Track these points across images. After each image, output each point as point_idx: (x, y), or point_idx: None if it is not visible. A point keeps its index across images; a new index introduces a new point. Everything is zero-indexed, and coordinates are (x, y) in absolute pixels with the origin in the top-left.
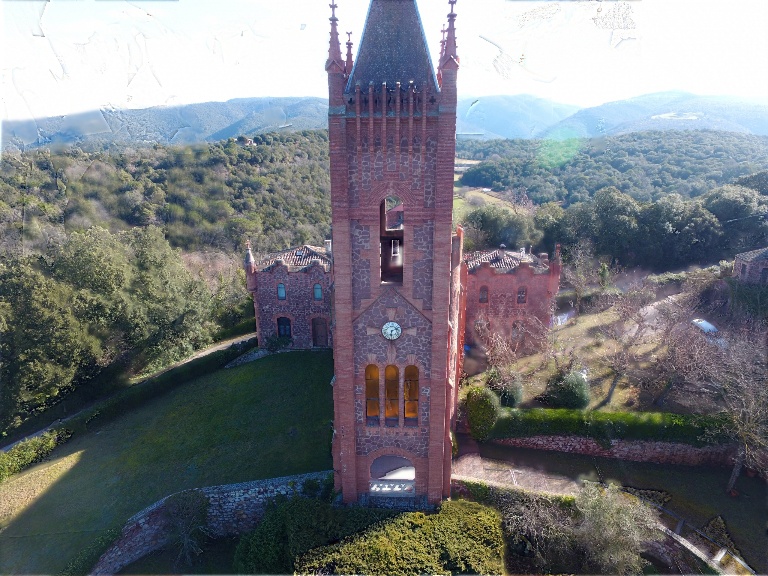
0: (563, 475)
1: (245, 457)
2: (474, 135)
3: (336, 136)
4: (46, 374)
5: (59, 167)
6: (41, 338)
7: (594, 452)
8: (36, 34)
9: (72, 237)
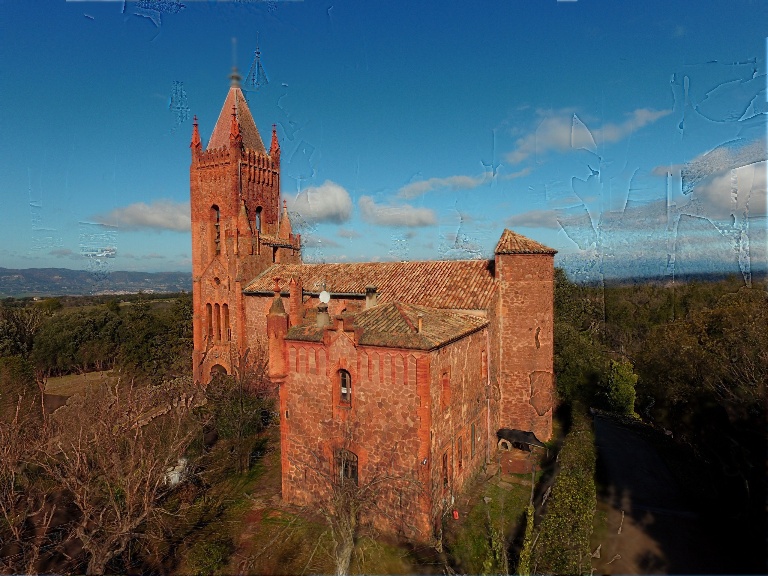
0: None
1: None
2: None
3: None
4: None
5: (767, 228)
6: None
7: None
8: None
9: None
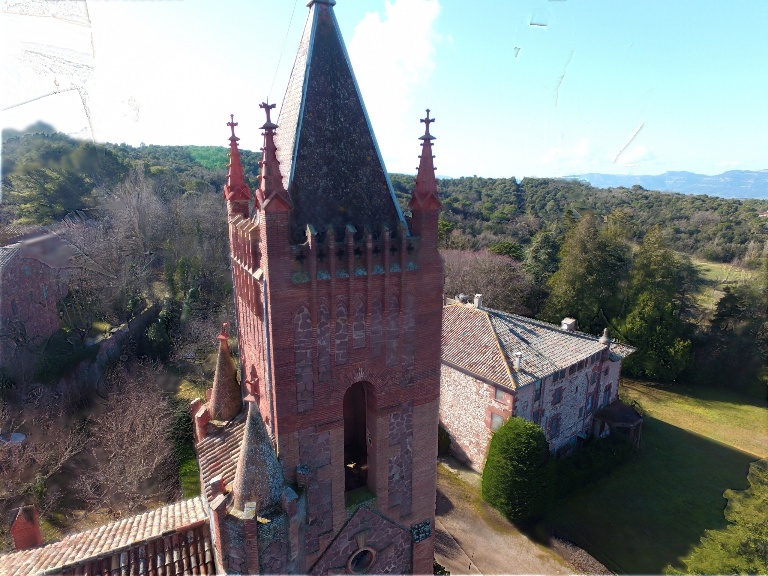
0: None
1: None
2: None
3: None
4: None
5: None
6: None
7: None
8: None
9: None
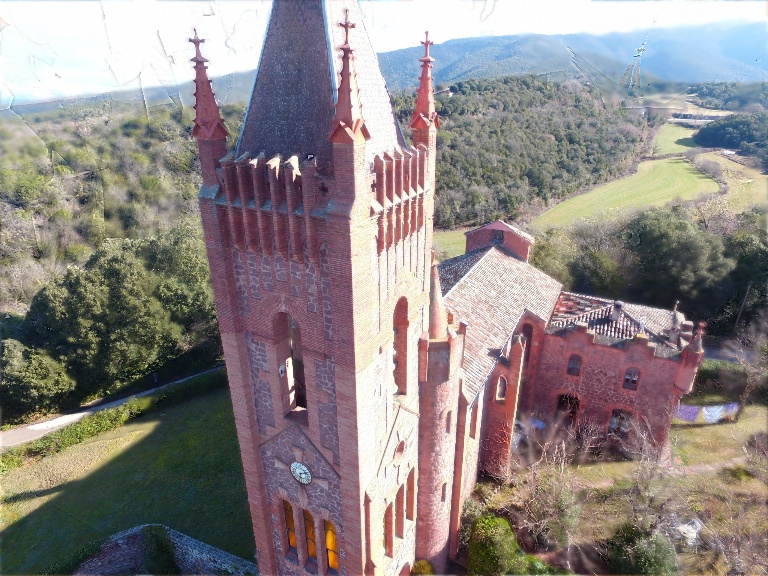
0: None
1: (236, 498)
2: (666, 109)
3: (209, 226)
4: (130, 353)
5: None
6: (133, 319)
7: None
8: (206, 14)
9: (182, 222)
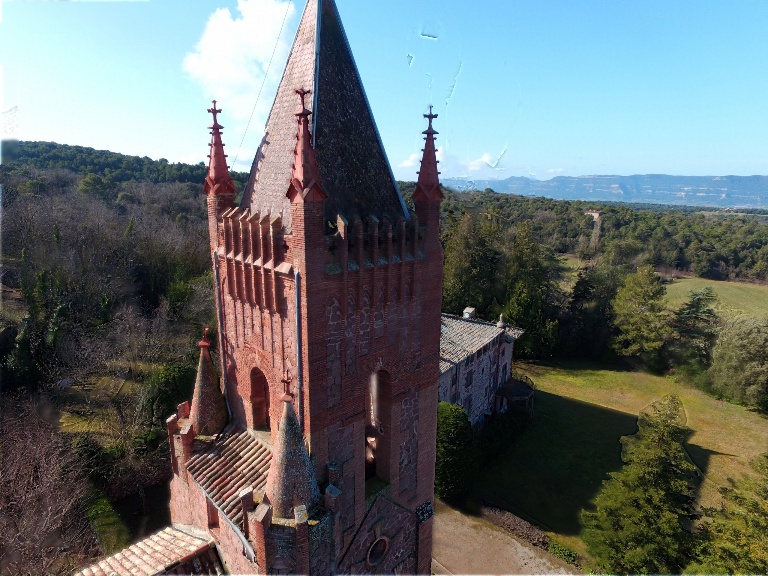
0: None
1: None
2: None
3: None
4: None
5: None
6: None
7: None
8: None
9: None
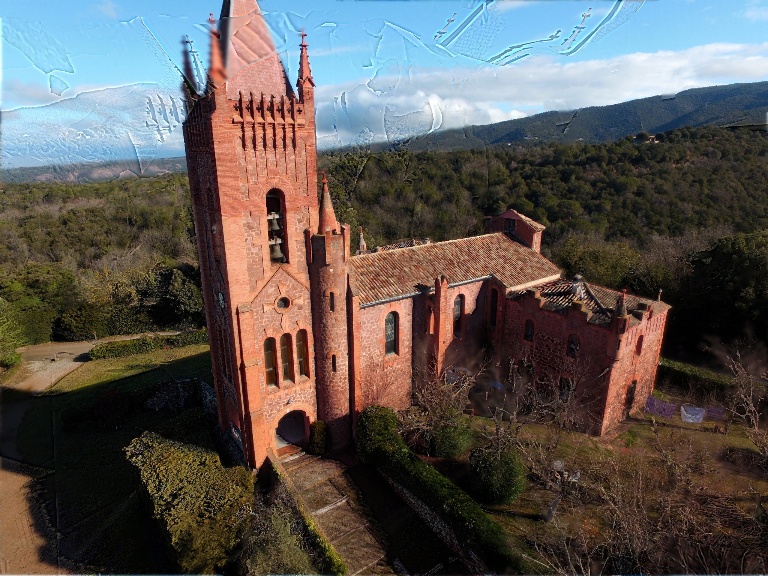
0: (387, 540)
1: None
2: None
3: (185, 140)
4: None
5: None
6: None
7: (459, 553)
8: (366, 65)
9: None
